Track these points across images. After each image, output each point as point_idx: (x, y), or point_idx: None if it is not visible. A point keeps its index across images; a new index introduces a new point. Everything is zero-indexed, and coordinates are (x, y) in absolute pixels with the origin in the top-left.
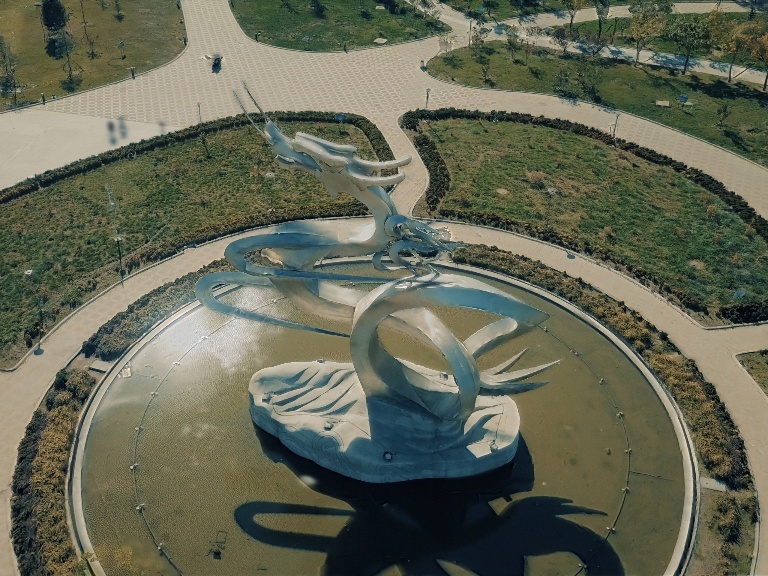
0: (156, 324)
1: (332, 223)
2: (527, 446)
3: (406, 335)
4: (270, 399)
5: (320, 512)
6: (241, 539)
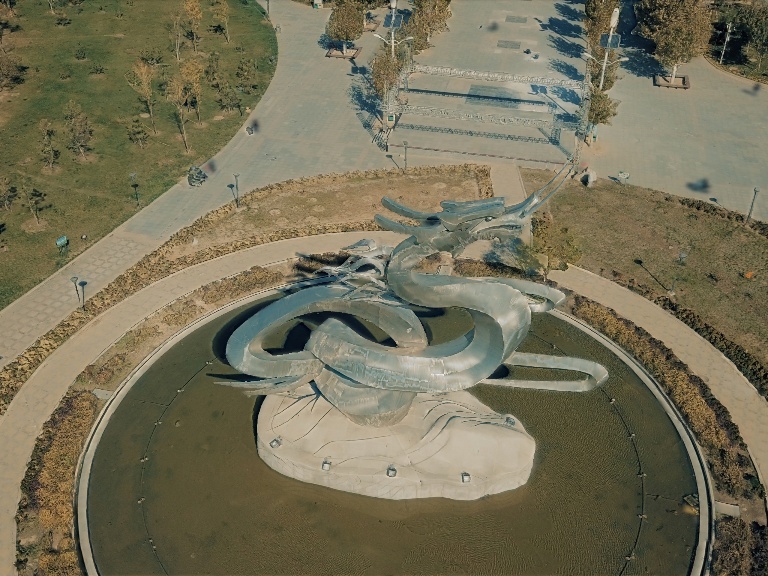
0: (708, 575)
1: (458, 283)
2: (254, 427)
3: (366, 572)
4: (507, 420)
5: None
6: None
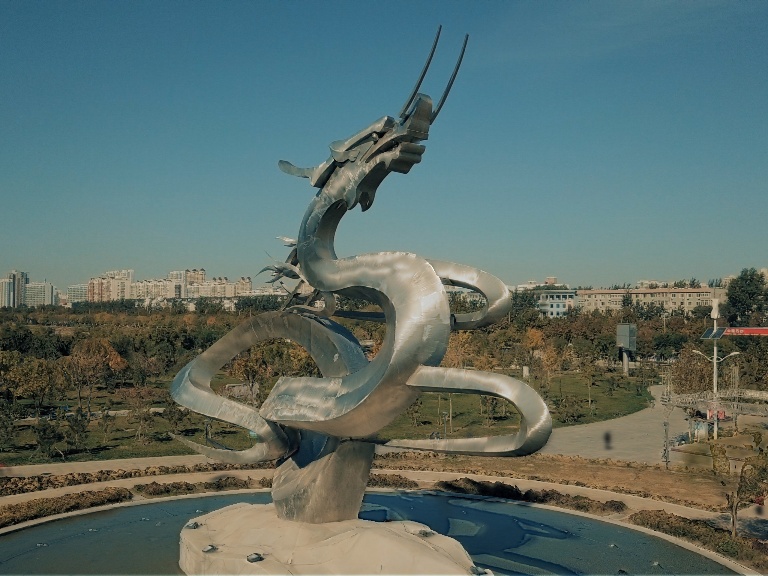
0: None
1: None
2: None
3: None
4: None
5: (486, 565)
6: (590, 573)
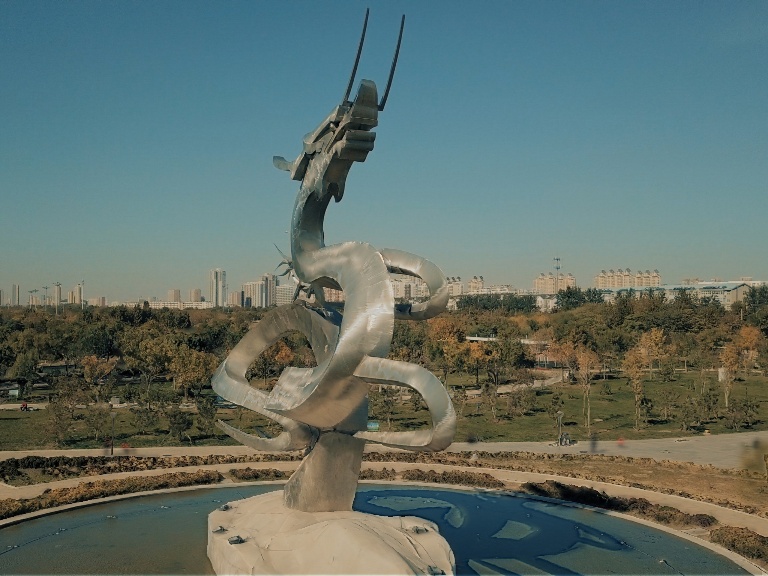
0: None
1: None
2: None
3: None
4: None
5: (504, 570)
6: None
